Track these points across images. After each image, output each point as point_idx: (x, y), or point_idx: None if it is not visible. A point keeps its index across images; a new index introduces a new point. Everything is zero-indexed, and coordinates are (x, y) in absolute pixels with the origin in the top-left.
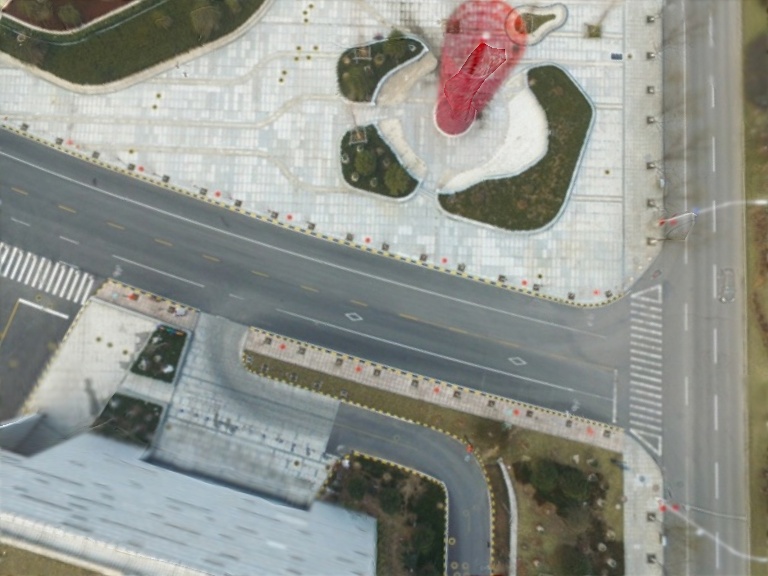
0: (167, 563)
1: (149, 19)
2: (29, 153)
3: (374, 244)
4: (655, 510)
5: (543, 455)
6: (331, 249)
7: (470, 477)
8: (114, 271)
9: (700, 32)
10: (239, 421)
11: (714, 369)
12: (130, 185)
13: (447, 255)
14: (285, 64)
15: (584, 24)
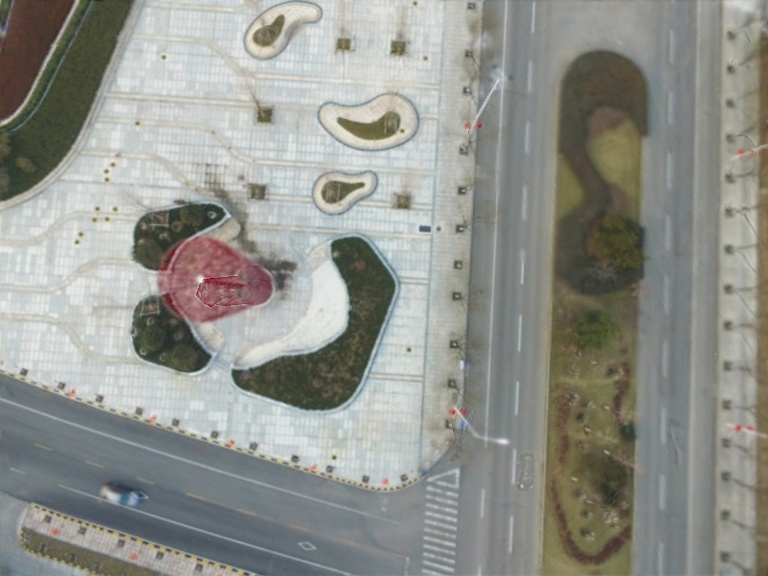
0: None
1: None
2: None
3: (162, 420)
4: None
5: None
6: (119, 423)
7: None
8: None
9: (512, 205)
10: None
11: (508, 559)
12: None
13: (237, 435)
14: (82, 225)
15: (393, 194)
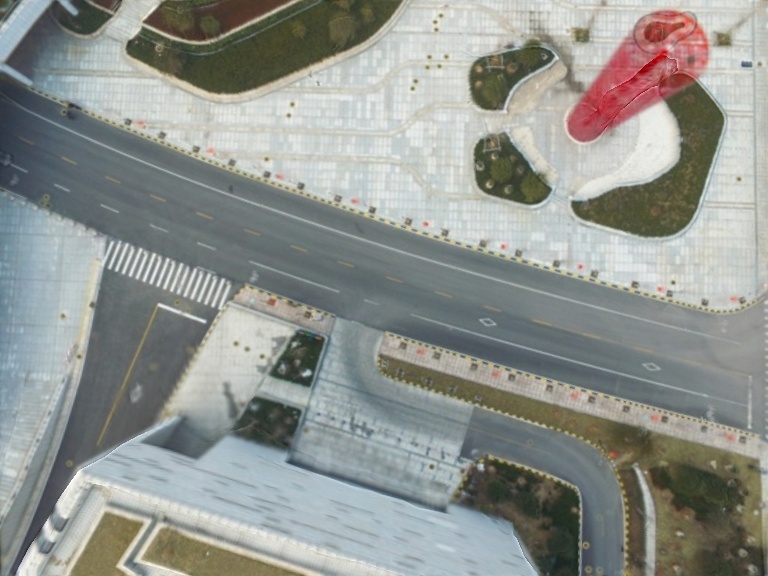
0: (362, 565)
1: (284, 29)
2: (167, 161)
3: (508, 250)
4: None
5: (681, 460)
6: (464, 255)
7: (603, 482)
8: (251, 276)
9: None
10: (375, 425)
11: None
12: (266, 192)
13: (581, 261)
14: (416, 73)
15: (713, 32)
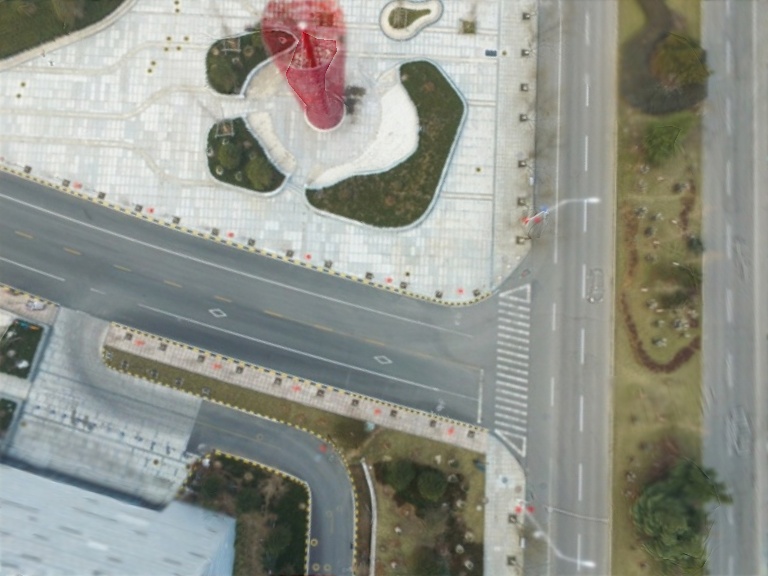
0: None
1: (13, 6)
2: None
3: (239, 239)
4: (516, 512)
5: (404, 455)
6: (196, 244)
7: (334, 477)
8: None
9: (576, 30)
10: (97, 418)
11: (581, 370)
12: None
13: (313, 251)
14: (154, 54)
15: (459, 20)
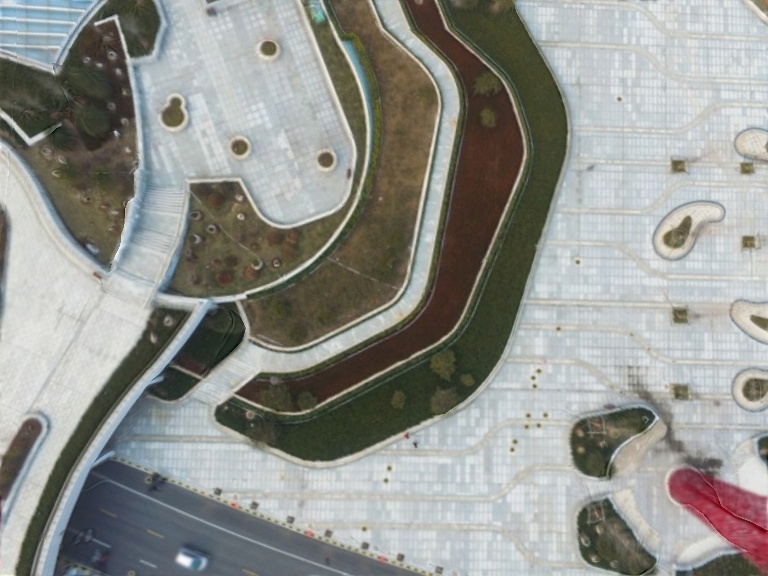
0: None
1: (381, 394)
2: (259, 532)
3: None
4: None
5: None
6: None
7: None
8: None
9: None
10: None
11: None
12: (364, 564)
13: None
14: (515, 433)
15: None
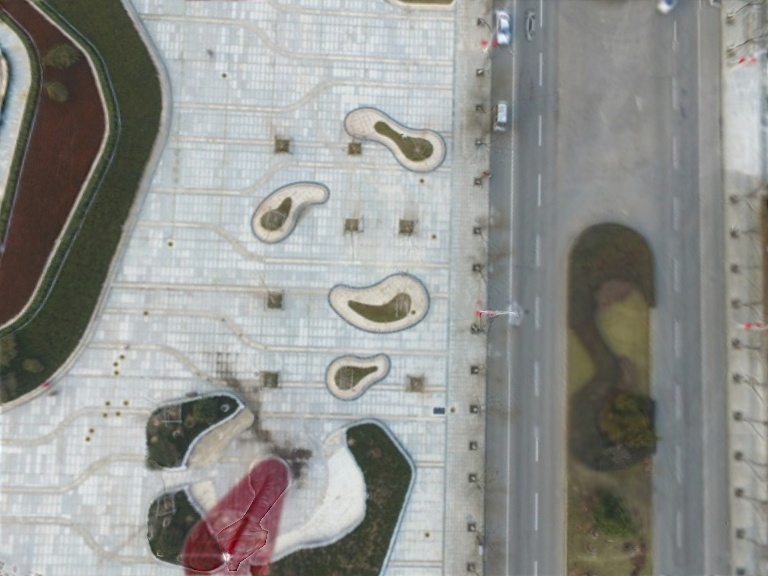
0: None
1: None
2: None
3: None
4: None
5: None
6: None
7: None
8: None
9: (525, 382)
10: None
11: None
12: None
13: None
14: (93, 421)
15: (407, 376)
